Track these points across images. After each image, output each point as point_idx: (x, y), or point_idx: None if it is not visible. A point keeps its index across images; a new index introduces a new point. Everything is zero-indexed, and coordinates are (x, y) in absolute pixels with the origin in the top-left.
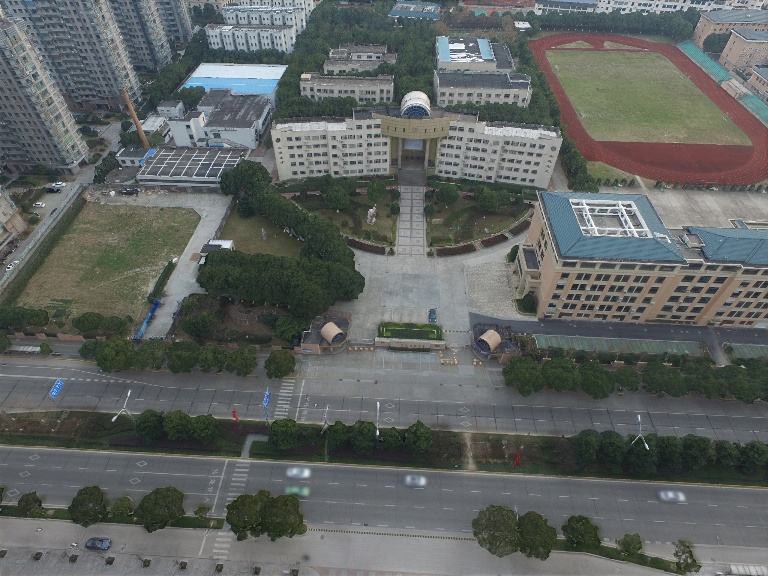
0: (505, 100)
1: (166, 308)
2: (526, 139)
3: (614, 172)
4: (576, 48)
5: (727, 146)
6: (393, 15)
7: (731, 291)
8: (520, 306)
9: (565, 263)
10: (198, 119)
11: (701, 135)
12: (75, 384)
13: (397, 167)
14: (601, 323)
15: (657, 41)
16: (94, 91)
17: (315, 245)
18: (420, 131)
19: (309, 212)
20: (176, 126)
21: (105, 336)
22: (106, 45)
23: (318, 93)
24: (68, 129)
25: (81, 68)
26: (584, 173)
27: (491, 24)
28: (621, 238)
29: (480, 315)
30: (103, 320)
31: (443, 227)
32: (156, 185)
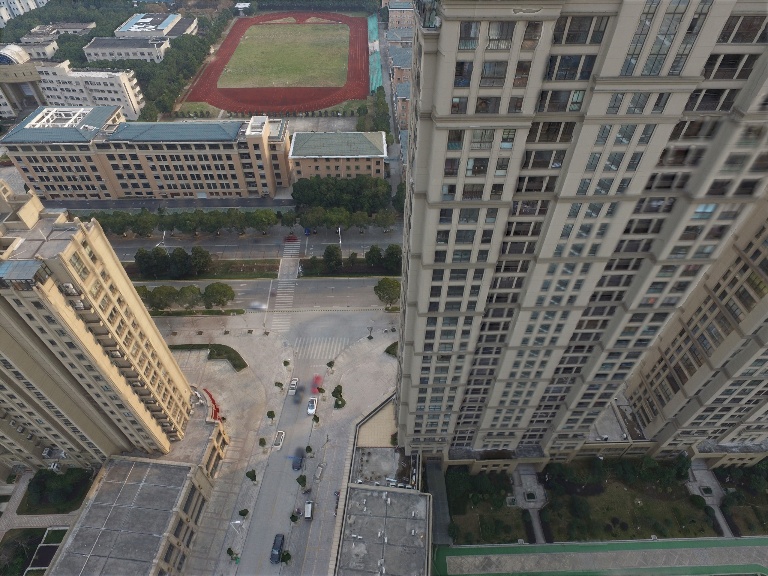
0: (143, 58)
1: None
2: (97, 79)
3: (207, 108)
4: (280, 23)
5: (321, 88)
6: None
7: (147, 165)
8: None
9: (9, 148)
10: None
11: (309, 81)
12: None
13: (19, 109)
14: (83, 201)
15: (356, 16)
16: None
17: None
18: (11, 75)
19: None
20: None
21: None
22: None
23: None
24: None
25: None
26: (166, 107)
27: None
28: (51, 128)
29: None
30: None
31: None
32: None
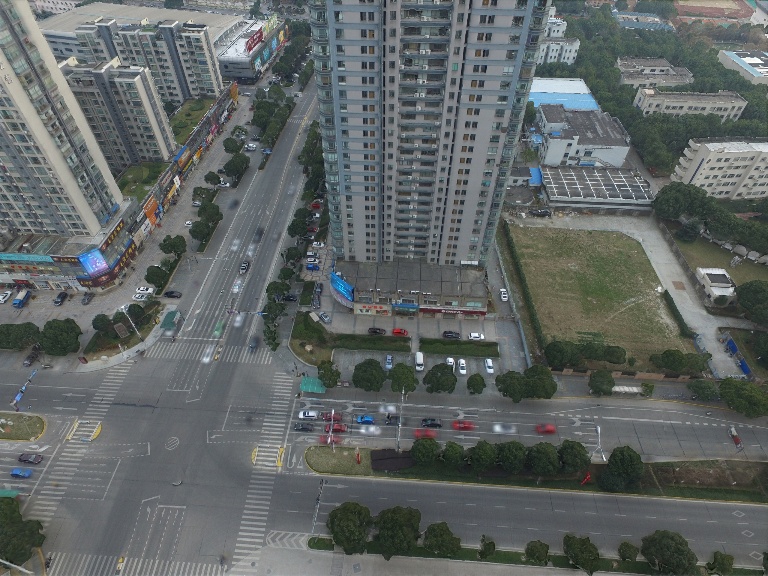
0: None
1: (707, 343)
2: None
3: None
4: None
5: None
6: None
7: None
8: None
9: None
10: (578, 137)
11: None
12: (697, 429)
13: None
14: None
15: None
16: None
17: None
18: None
19: None
20: (557, 144)
21: (689, 375)
22: None
23: (666, 109)
24: None
25: None
26: None
27: (728, 36)
28: None
29: None
30: (692, 358)
31: None
32: (568, 207)
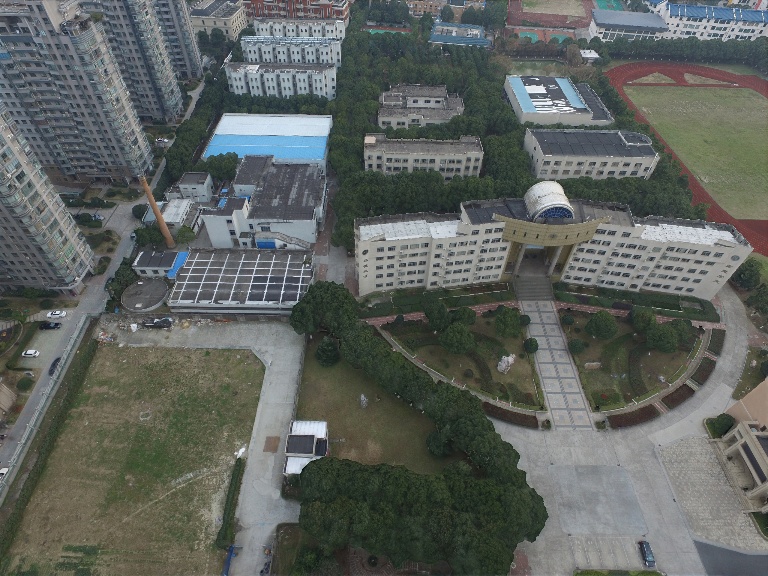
0: (623, 169)
1: (246, 557)
2: (699, 246)
3: None
4: (656, 83)
5: None
6: (435, 41)
7: None
8: (764, 527)
9: None
10: (242, 210)
11: None
12: None
13: (512, 273)
14: None
15: (742, 73)
16: (92, 161)
17: (457, 439)
18: (559, 237)
19: (412, 352)
20: (213, 221)
21: None
22: (110, 107)
23: (388, 163)
24: (67, 237)
25: (75, 135)
26: (757, 279)
27: (550, 52)
28: None
29: (712, 546)
30: None
31: (601, 373)
32: (195, 313)
